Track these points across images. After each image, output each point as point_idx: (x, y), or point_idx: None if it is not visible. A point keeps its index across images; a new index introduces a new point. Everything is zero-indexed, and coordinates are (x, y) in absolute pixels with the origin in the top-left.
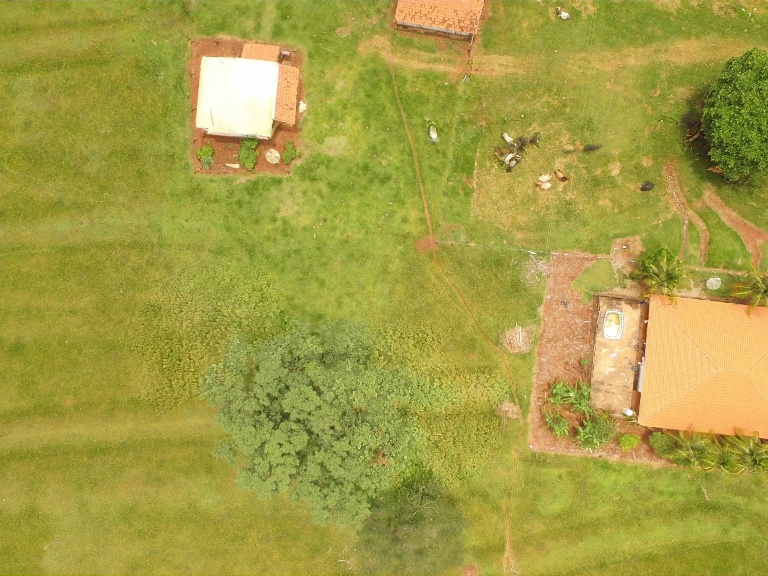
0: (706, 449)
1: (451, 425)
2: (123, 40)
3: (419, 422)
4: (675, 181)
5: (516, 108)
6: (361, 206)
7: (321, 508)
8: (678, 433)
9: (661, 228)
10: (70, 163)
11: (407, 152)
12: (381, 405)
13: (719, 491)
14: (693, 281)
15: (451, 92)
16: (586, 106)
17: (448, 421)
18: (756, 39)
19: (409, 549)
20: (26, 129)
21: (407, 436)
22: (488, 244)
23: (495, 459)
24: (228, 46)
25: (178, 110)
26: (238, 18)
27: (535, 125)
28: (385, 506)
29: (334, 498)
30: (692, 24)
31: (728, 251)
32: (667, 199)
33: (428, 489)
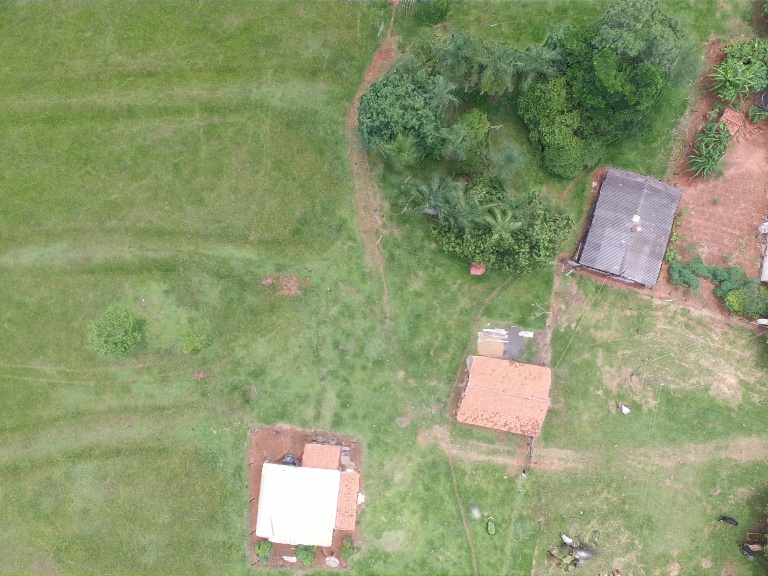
0: None
1: None
2: (183, 428)
3: None
4: None
5: (575, 504)
6: None
7: None
8: None
9: None
10: (127, 554)
11: (465, 548)
12: None
13: None
14: None
15: (510, 486)
16: (645, 503)
17: None
18: None
19: None
20: (84, 518)
21: None
22: None
23: None
24: (287, 435)
25: (236, 500)
26: (298, 406)
27: (594, 522)
28: None
29: None
30: (753, 421)
31: None
32: None
33: None
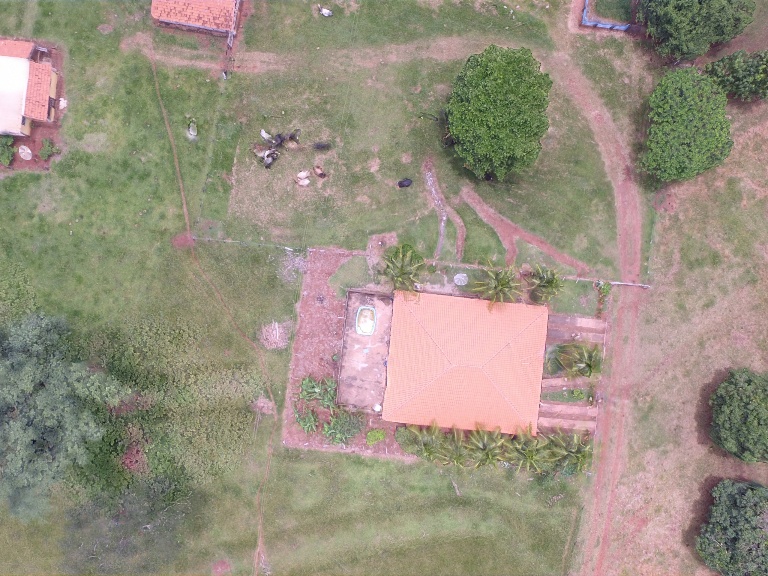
0: (440, 444)
1: (205, 421)
2: None
3: (173, 418)
4: (434, 178)
5: (277, 105)
6: (119, 203)
7: (73, 504)
8: (421, 428)
9: (418, 224)
10: None
11: (167, 149)
12: (134, 401)
13: (470, 486)
14: (447, 277)
15: (212, 89)
16: (347, 103)
17: (202, 417)
18: (517, 36)
19: (161, 545)
20: None
21: (160, 432)
22: (245, 240)
23: (248, 455)
24: None
25: None
26: None
27: (295, 122)
28: (137, 502)
29: (86, 494)
30: (454, 21)
31: (483, 247)
32: (425, 195)
33: (180, 485)
